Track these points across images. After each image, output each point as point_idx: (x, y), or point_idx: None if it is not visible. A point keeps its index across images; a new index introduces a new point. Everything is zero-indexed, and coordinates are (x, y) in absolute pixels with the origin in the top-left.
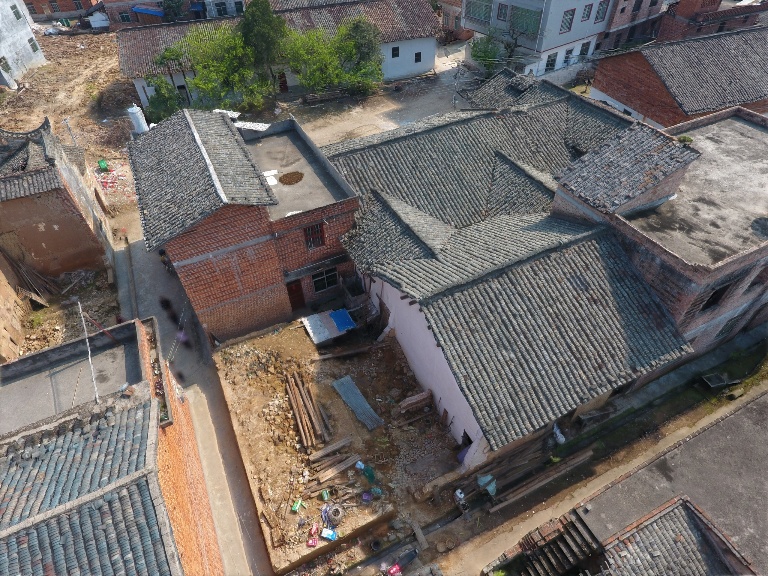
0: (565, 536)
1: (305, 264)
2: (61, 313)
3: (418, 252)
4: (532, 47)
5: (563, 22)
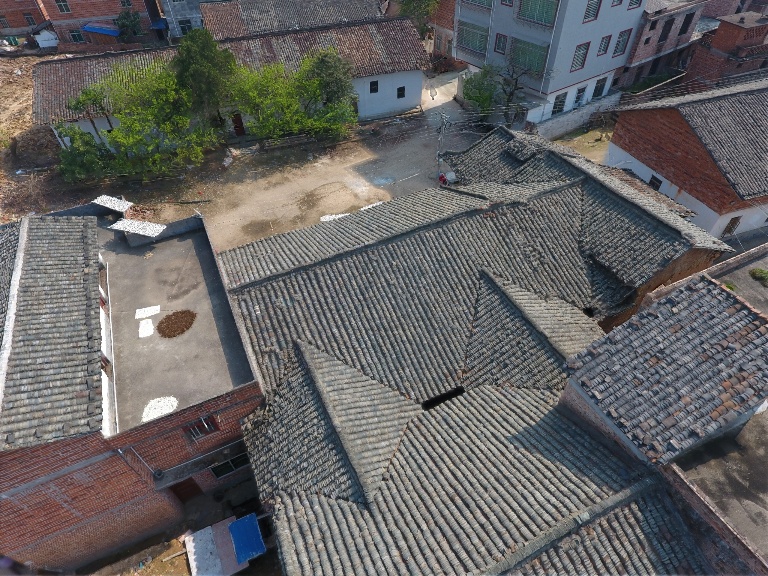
0: None
1: (191, 456)
2: None
3: (344, 485)
4: (536, 87)
5: (575, 58)
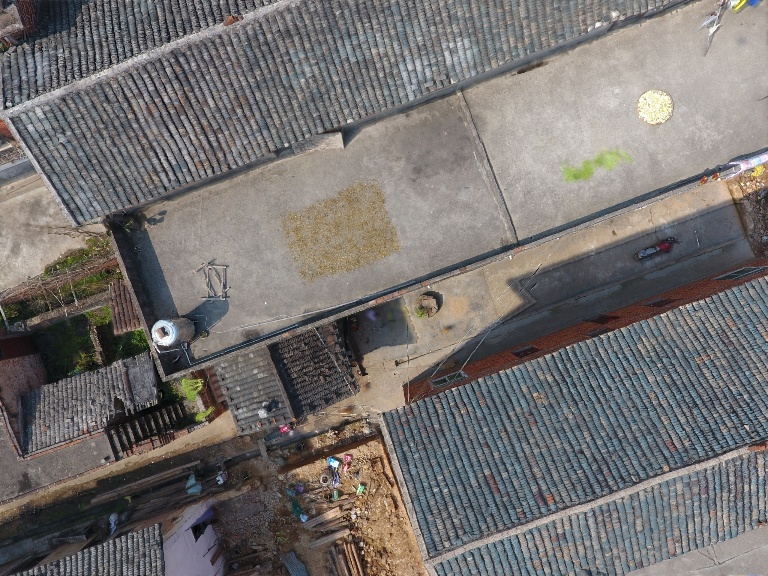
0: (134, 441)
1: None
2: None
3: None
4: None
5: None
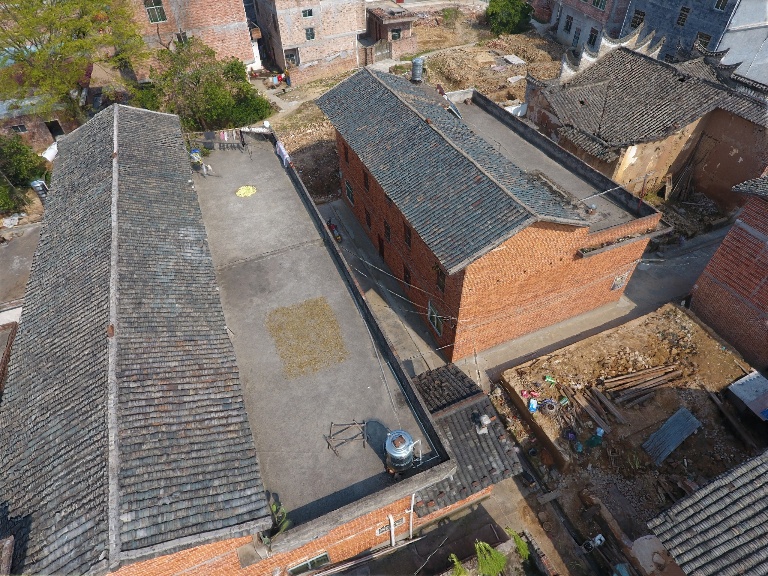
0: None
1: None
2: (662, 206)
3: None
4: None
5: None
